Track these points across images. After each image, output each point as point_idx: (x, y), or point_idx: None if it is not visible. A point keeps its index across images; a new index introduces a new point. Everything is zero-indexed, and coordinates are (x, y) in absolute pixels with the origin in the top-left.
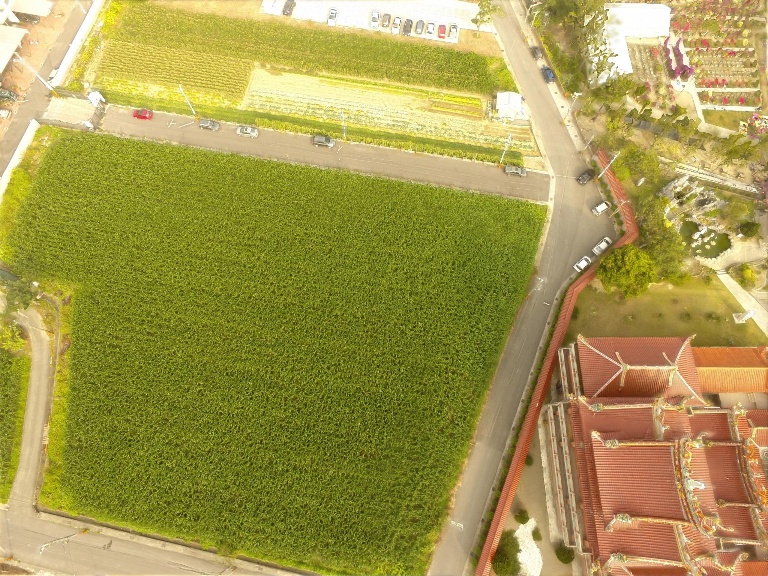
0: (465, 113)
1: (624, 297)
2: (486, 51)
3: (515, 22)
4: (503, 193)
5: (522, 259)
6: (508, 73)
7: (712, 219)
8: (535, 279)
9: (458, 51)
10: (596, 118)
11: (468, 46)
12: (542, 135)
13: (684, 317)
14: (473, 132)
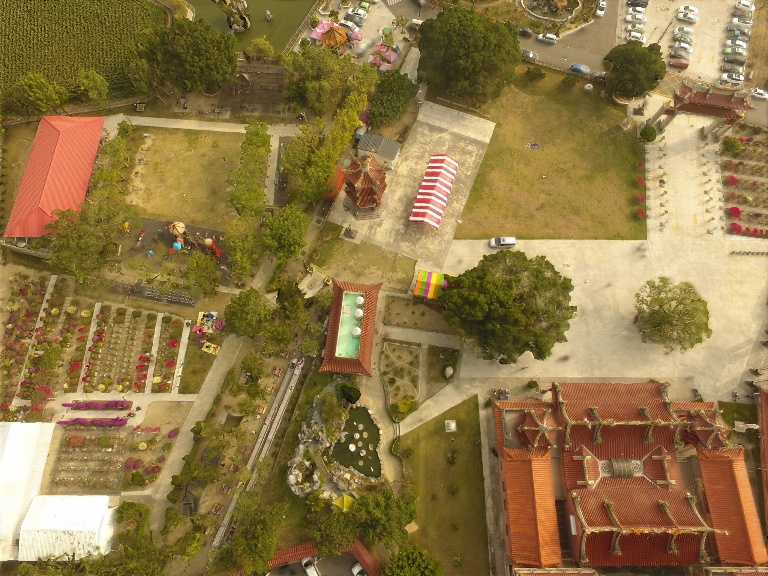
0: None
1: None
2: None
3: None
4: None
5: None
6: None
7: (333, 427)
8: None
9: None
10: None
11: None
12: None
13: (454, 494)
14: None
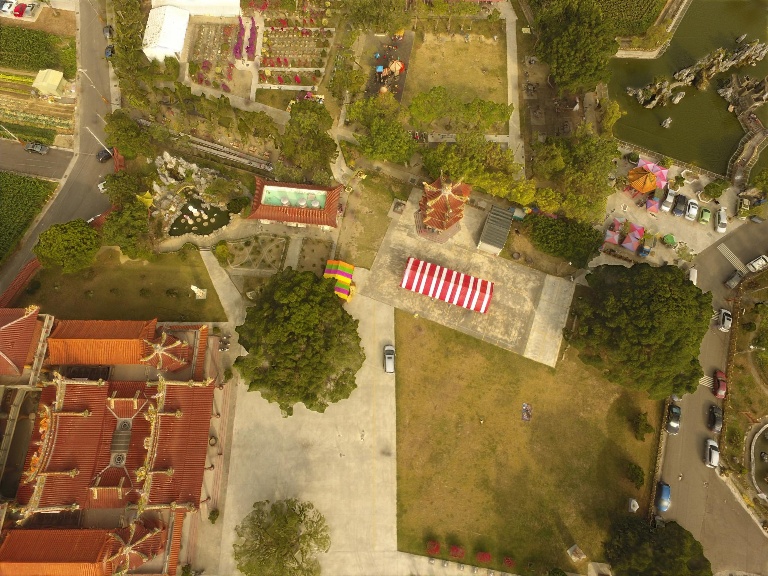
0: (15, 91)
1: (89, 273)
2: (60, 30)
3: (101, 1)
4: (18, 170)
5: (1, 235)
6: (71, 52)
7: (214, 196)
8: (16, 255)
9: (25, 29)
10: (146, 97)
11: (44, 25)
12: (83, 113)
13: None
14: (16, 110)
